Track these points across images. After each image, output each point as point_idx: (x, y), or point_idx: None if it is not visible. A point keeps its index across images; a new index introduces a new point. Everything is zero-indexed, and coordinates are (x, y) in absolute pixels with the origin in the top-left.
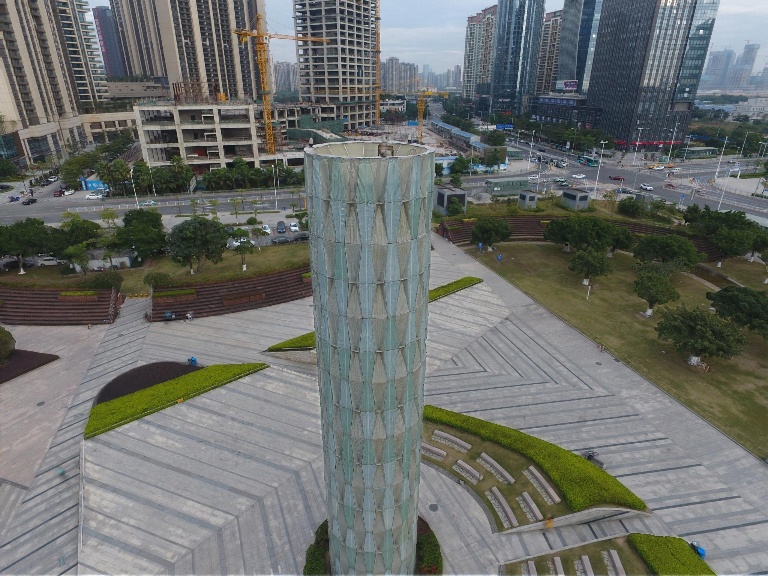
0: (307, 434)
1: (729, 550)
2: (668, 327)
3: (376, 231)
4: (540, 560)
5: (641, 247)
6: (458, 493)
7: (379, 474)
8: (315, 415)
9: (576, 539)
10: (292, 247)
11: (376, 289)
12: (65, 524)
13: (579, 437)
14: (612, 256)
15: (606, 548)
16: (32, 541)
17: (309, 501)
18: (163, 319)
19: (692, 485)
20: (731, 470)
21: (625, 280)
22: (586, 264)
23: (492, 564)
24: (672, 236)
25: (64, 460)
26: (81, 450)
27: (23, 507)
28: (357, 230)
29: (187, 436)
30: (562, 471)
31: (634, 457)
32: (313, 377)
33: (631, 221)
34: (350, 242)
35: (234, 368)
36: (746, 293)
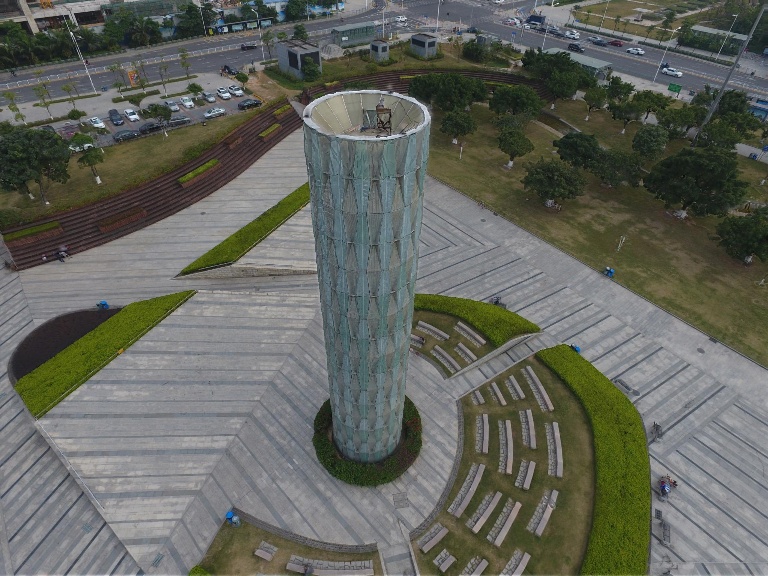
0: (265, 346)
1: (591, 342)
2: (533, 181)
3: (395, 199)
4: (482, 388)
5: (496, 100)
6: (410, 358)
7: (388, 376)
8: (264, 327)
9: (501, 365)
10: (143, 143)
11: (392, 245)
12: (66, 498)
13: (484, 288)
14: (469, 109)
15: (523, 366)
16: (41, 524)
17: (294, 402)
18: (32, 264)
19: (564, 304)
20: (585, 286)
21: (485, 134)
22: (455, 125)
23: (451, 402)
24: (520, 86)
25: (18, 444)
26: (40, 431)
27: (5, 500)
28: (379, 201)
29: (148, 383)
30: (482, 320)
31: (524, 293)
32: (247, 292)
33: (479, 69)
34: (372, 212)
35: (159, 303)
36: (582, 138)
